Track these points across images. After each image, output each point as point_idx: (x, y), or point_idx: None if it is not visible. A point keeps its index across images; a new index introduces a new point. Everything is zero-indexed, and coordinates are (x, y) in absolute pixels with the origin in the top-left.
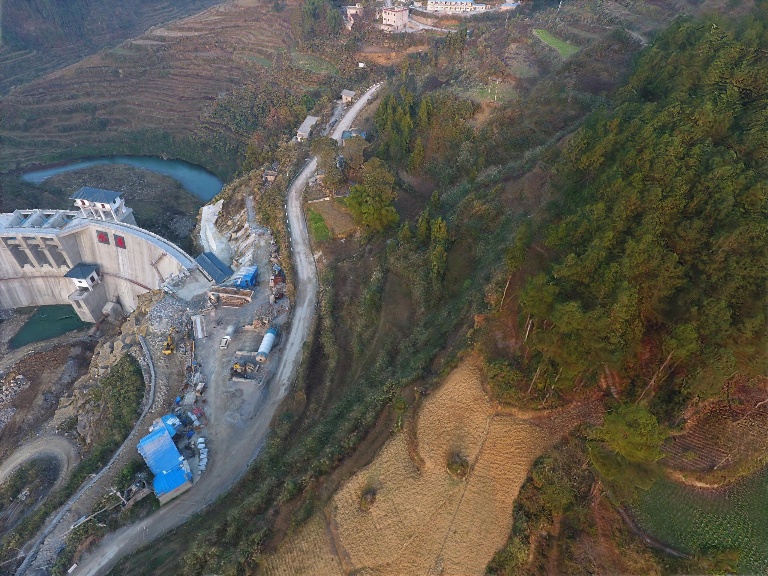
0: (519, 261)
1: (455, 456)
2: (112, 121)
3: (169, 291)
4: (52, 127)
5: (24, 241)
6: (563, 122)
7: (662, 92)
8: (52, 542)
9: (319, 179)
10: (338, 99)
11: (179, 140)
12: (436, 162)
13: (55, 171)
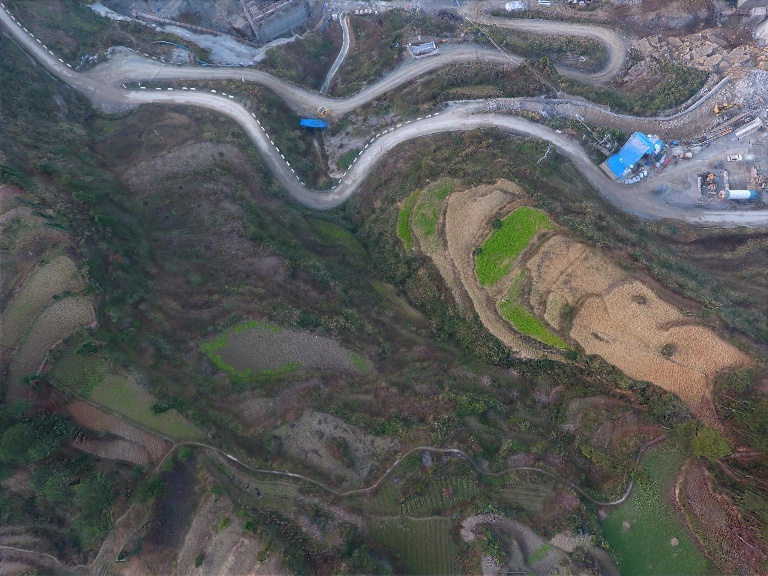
0: None
1: (674, 349)
2: None
3: None
4: None
5: None
6: None
7: None
8: None
9: None
10: None
11: None
12: None
13: None
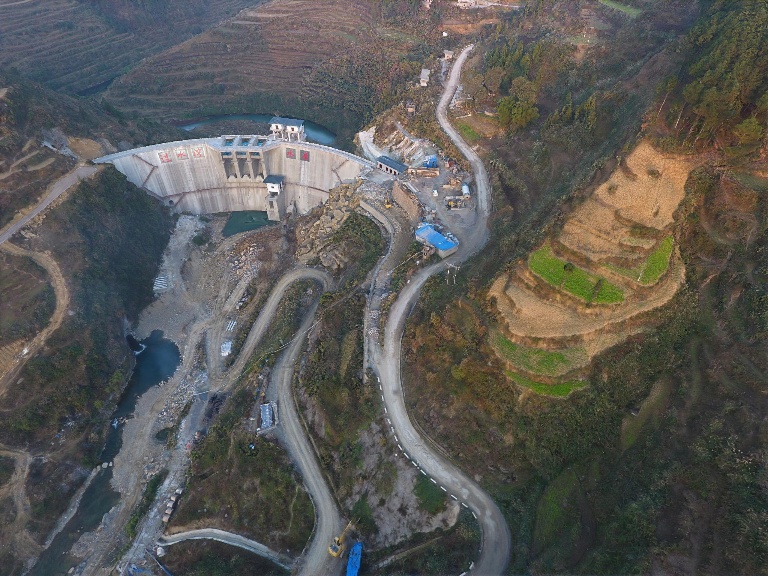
0: (676, 83)
1: None
2: (228, 87)
3: (366, 178)
4: (181, 91)
5: (236, 156)
6: (645, 52)
7: (734, 8)
8: (381, 280)
9: (458, 104)
10: (439, 58)
11: (289, 100)
12: (550, 86)
13: (192, 125)
